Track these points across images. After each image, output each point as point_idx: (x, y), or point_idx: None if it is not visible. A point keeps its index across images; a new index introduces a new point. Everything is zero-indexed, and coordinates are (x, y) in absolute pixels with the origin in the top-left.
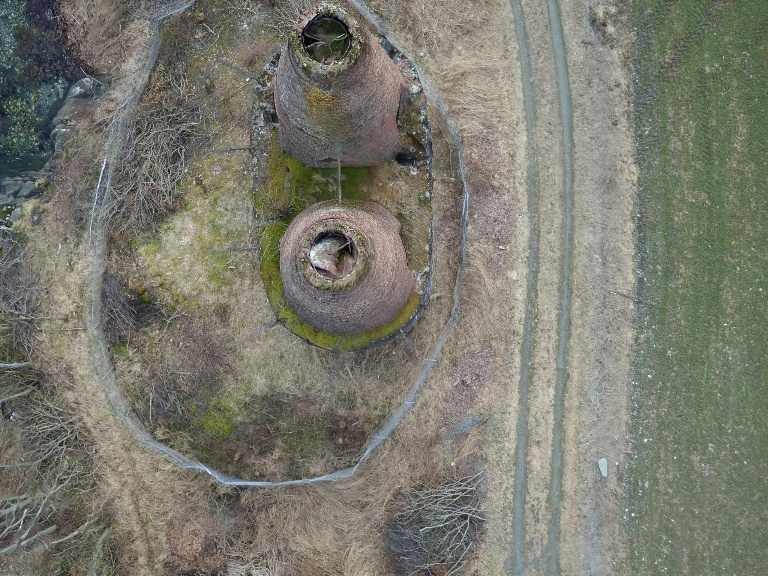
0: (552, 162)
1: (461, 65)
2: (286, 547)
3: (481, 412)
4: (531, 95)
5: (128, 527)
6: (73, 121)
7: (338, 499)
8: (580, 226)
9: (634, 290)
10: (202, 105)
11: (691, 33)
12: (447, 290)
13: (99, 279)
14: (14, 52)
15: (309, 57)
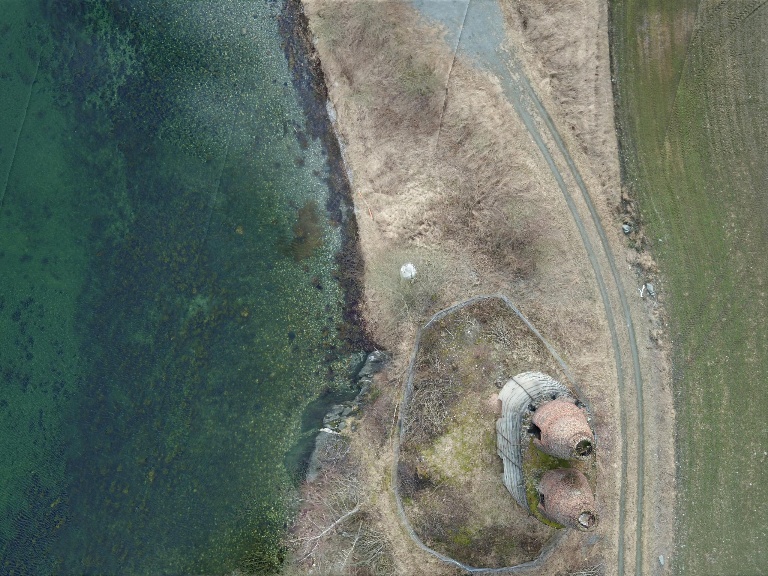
0: (633, 409)
1: (586, 360)
2: None
3: (600, 534)
4: (621, 375)
5: None
6: (371, 375)
7: None
8: (647, 440)
9: (675, 472)
10: (451, 377)
11: (700, 345)
12: None
13: (396, 464)
14: (336, 337)
15: (578, 454)
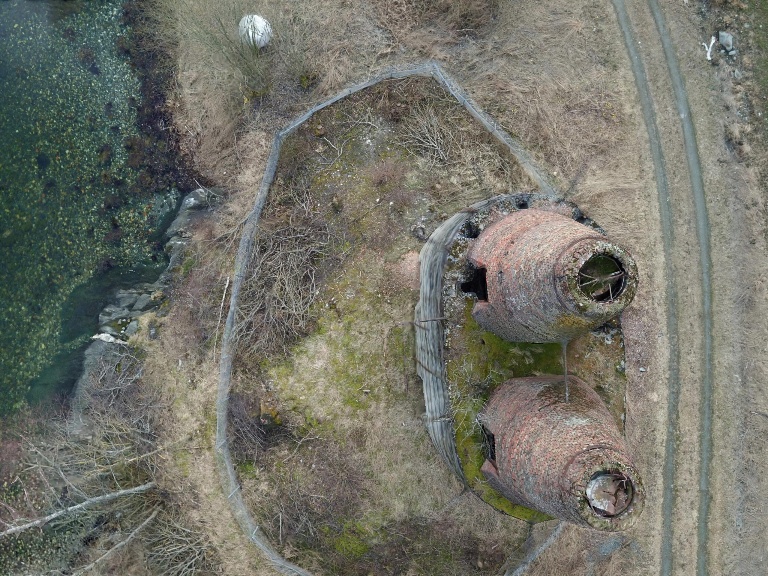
0: (690, 282)
1: (596, 185)
2: None
3: (624, 535)
4: (668, 215)
5: None
6: (188, 233)
7: None
8: (720, 346)
9: None
10: (329, 224)
11: None
12: None
13: (224, 398)
14: (125, 163)
15: (584, 295)
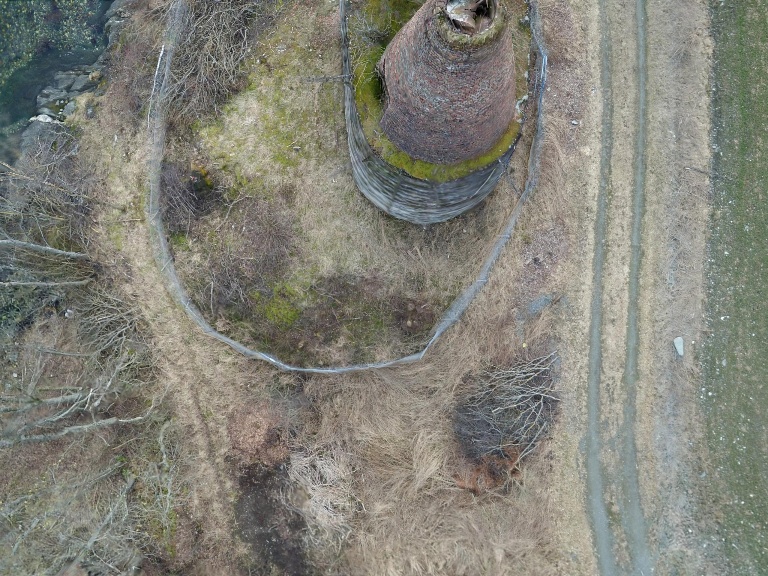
0: (625, 36)
1: None
2: (351, 437)
3: (554, 291)
4: None
5: (188, 421)
6: (127, 13)
7: (405, 386)
8: (654, 101)
9: (710, 166)
10: None
11: None
12: (520, 164)
13: (157, 168)
14: None
15: None
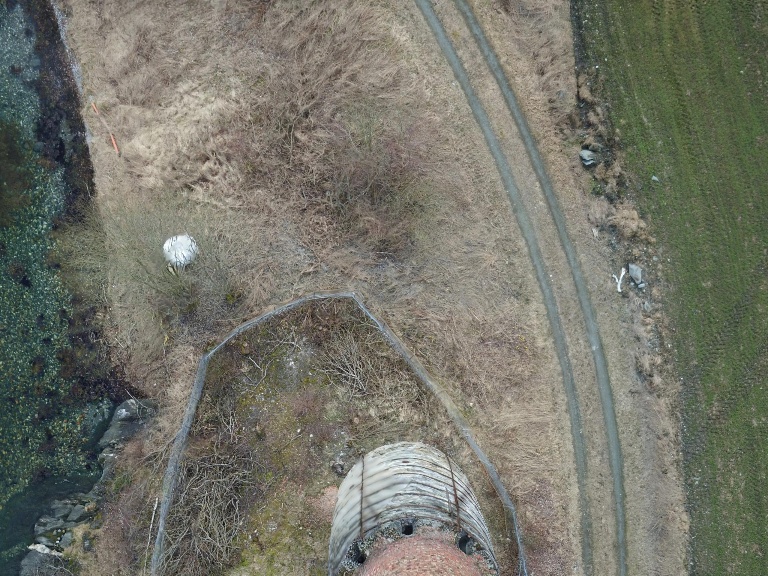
0: (604, 513)
1: (511, 418)
2: None
3: None
4: (581, 447)
5: None
6: (120, 445)
7: None
8: (634, 575)
9: None
10: (253, 451)
11: (737, 386)
12: None
13: None
14: (58, 374)
15: None
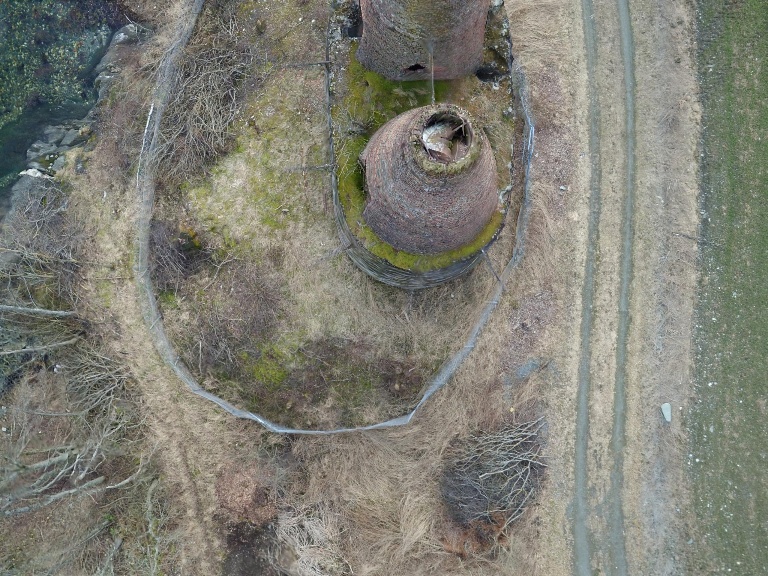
0: (613, 101)
1: (520, 2)
2: (339, 498)
3: (541, 356)
4: (592, 33)
5: (176, 479)
6: (117, 68)
7: (393, 448)
8: (642, 166)
9: (698, 231)
10: (253, 46)
11: None
12: (508, 230)
13: (146, 226)
14: None
15: None
